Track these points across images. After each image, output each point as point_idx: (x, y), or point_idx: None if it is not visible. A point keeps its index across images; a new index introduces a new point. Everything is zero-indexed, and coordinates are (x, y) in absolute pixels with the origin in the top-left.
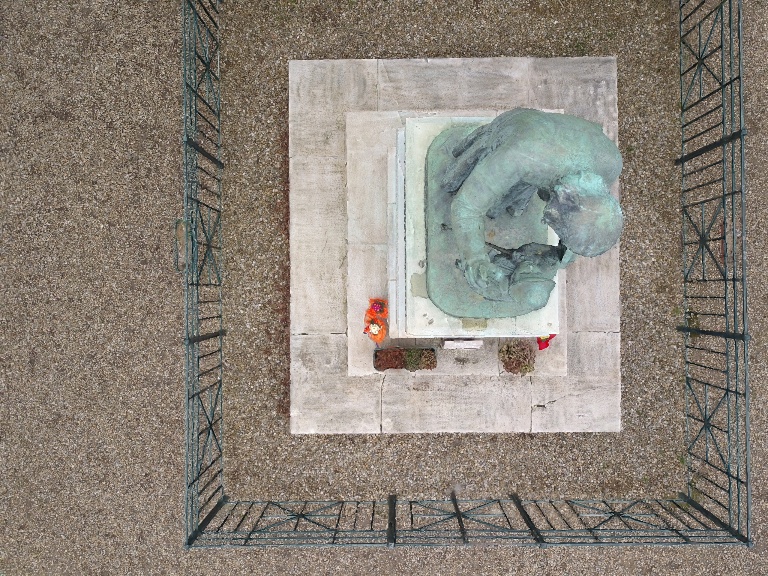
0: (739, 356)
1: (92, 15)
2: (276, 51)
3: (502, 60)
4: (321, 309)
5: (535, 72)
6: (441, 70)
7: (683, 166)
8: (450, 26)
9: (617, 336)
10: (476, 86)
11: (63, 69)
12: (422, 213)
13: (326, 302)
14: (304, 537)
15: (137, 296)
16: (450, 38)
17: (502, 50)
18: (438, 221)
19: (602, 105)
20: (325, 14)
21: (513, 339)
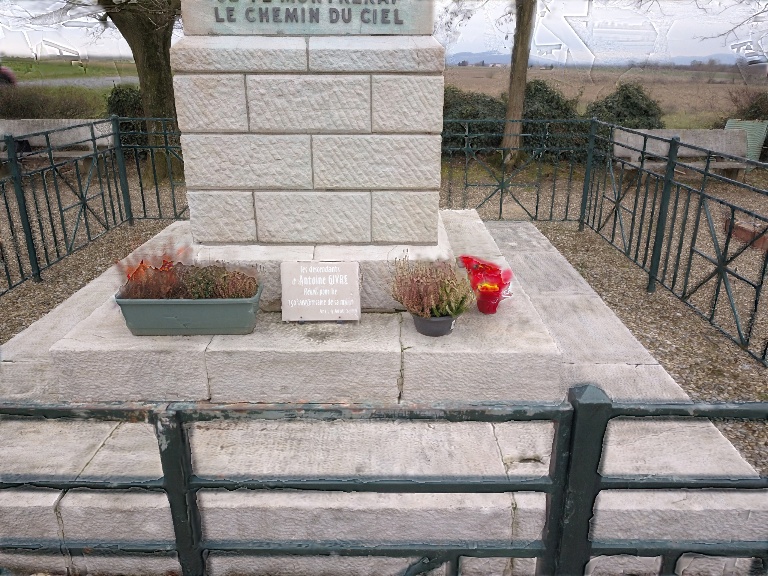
0: None
1: None
2: None
3: None
4: None
5: None
6: None
7: None
8: None
9: (657, 369)
10: None
11: None
12: None
13: None
14: None
15: None
16: None
17: None
18: None
19: (525, 235)
20: None
21: None
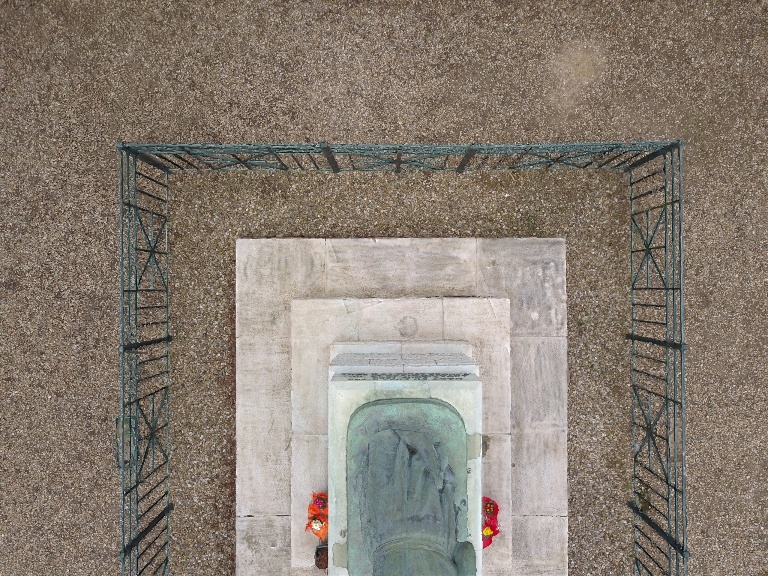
0: (690, 530)
1: (41, 184)
2: (225, 223)
3: (450, 241)
4: (267, 491)
5: (483, 253)
6: (389, 250)
7: (633, 343)
8: (400, 199)
9: (564, 520)
10: (424, 267)
11: (11, 238)
12: (344, 482)
13: (272, 484)
14: None
15: (84, 467)
16: (400, 211)
17: (452, 223)
18: (357, 501)
19: (550, 287)
20: (275, 185)
21: None
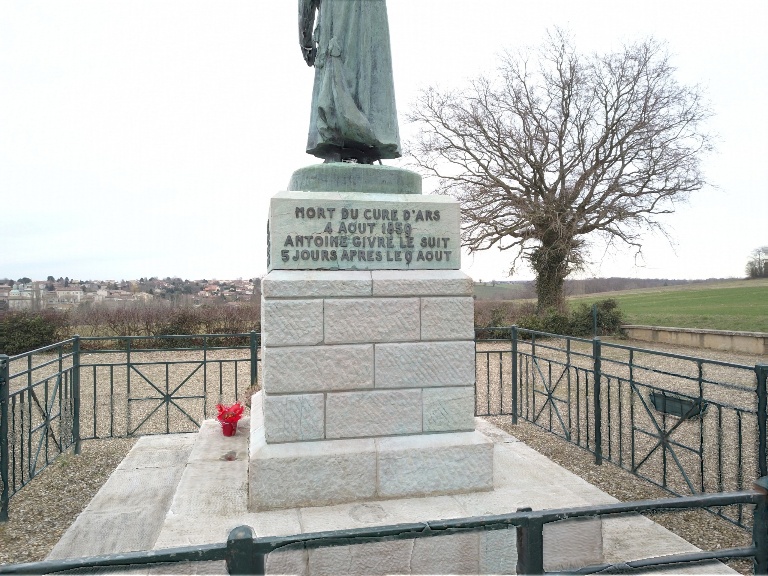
0: None
1: None
2: None
3: None
4: None
5: None
6: None
7: None
8: None
9: None
10: None
11: None
12: None
13: None
14: None
15: None
16: None
17: None
18: None
19: None
20: None
21: None
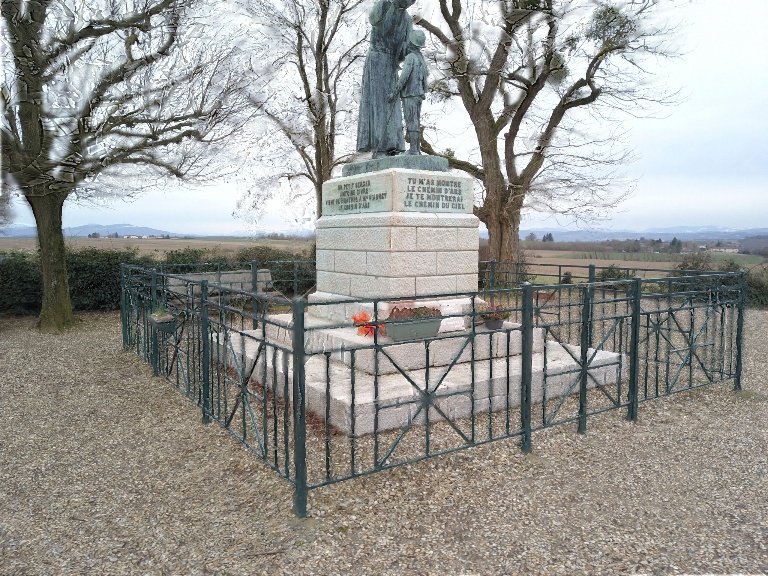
0: None
1: None
2: None
3: None
4: None
5: None
6: None
7: None
8: None
9: None
10: None
11: None
12: None
13: None
14: (441, 317)
15: None
16: None
17: None
18: None
19: None
20: None
21: None
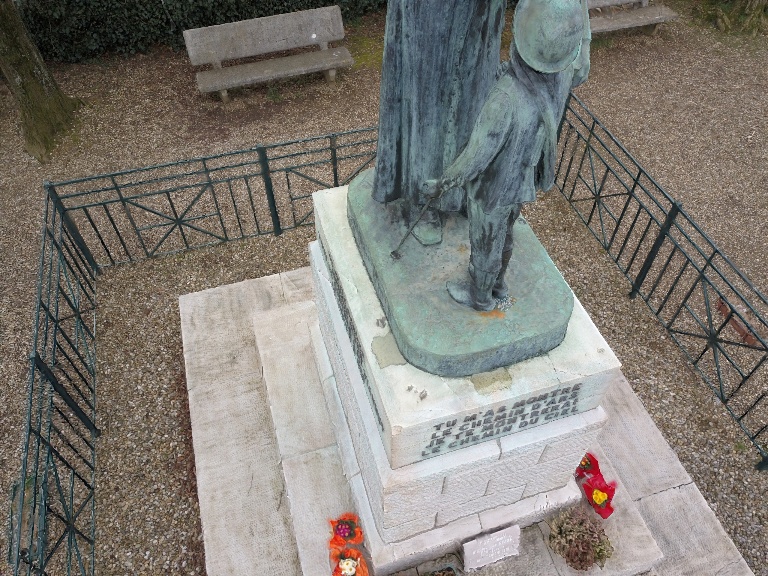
0: None
1: None
2: (164, 300)
3: None
4: None
5: None
6: None
7: (640, 294)
8: None
9: (693, 488)
10: None
11: None
12: (361, 268)
13: (266, 569)
14: None
15: None
16: None
17: None
18: (385, 252)
19: None
20: (216, 260)
21: (560, 511)
